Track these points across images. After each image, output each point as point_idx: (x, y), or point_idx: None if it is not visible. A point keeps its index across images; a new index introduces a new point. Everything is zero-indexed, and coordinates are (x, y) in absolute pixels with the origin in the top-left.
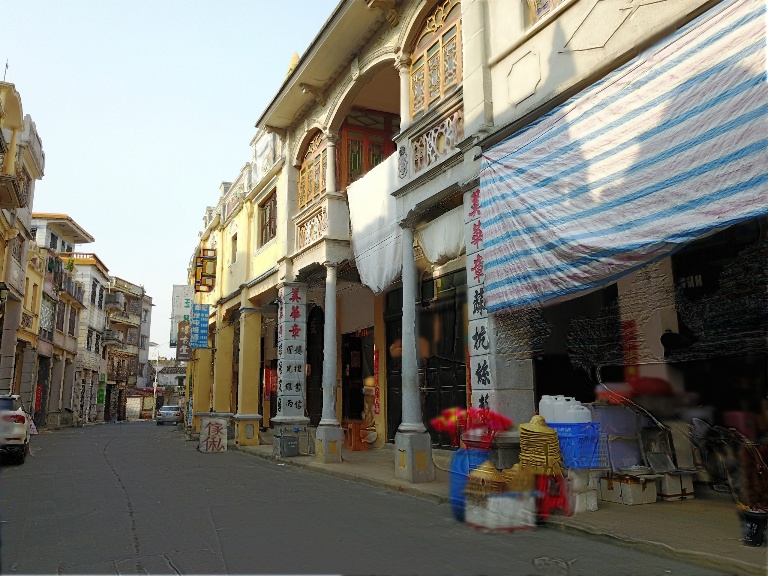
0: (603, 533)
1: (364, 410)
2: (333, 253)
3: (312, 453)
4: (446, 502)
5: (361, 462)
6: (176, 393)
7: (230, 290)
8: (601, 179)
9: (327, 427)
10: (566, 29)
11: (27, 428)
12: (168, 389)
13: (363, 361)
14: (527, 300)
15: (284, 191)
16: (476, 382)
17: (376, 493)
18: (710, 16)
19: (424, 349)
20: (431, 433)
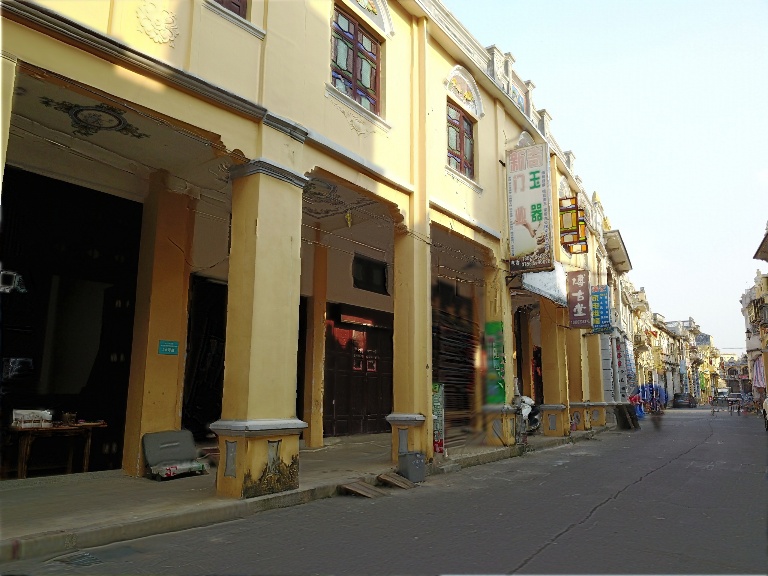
0: None
1: None
2: None
3: None
4: None
5: None
6: None
7: None
8: None
9: None
10: None
11: (765, 409)
12: None
13: None
14: None
15: None
16: None
17: None
18: None
19: None
20: None
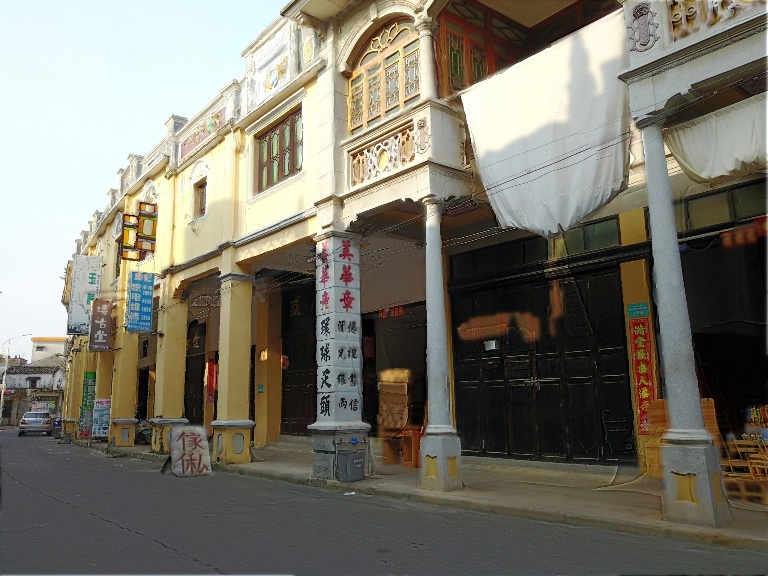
0: None
1: (380, 412)
2: (440, 184)
3: (375, 474)
4: None
5: (490, 487)
6: (29, 397)
7: (192, 253)
8: None
9: (445, 437)
10: None
11: None
12: (18, 392)
13: (378, 350)
14: None
15: (326, 106)
16: None
17: (681, 550)
18: None
19: (709, 311)
20: (549, 441)
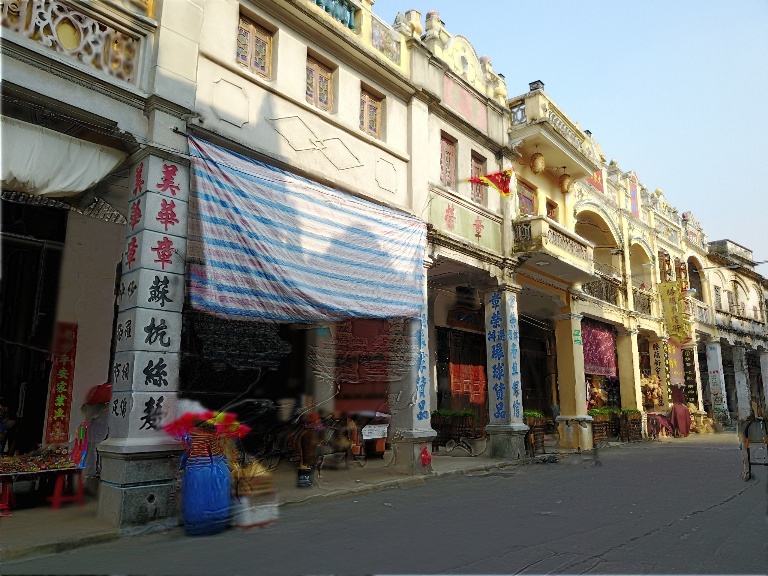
0: (285, 502)
1: None
2: None
3: None
4: (86, 544)
5: None
6: None
7: None
8: (311, 250)
9: None
10: (273, 107)
11: None
12: None
13: None
14: (261, 316)
15: None
16: (144, 382)
17: None
18: (369, 206)
19: None
20: None
